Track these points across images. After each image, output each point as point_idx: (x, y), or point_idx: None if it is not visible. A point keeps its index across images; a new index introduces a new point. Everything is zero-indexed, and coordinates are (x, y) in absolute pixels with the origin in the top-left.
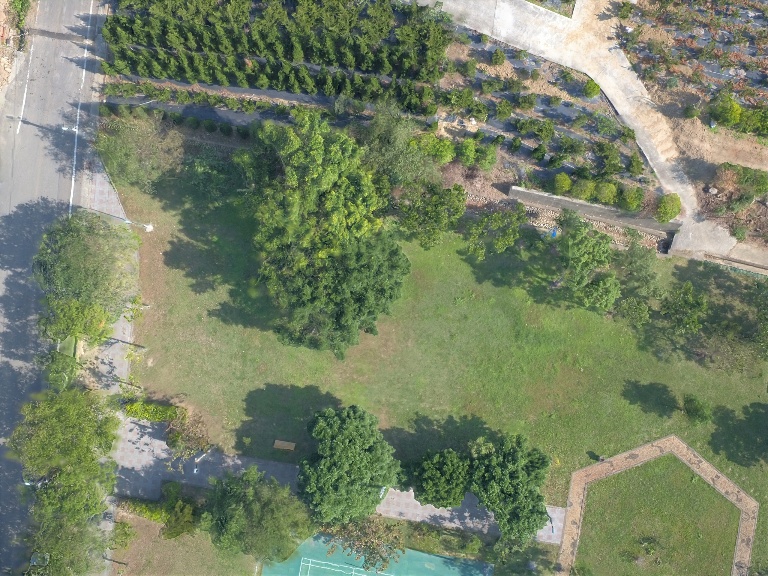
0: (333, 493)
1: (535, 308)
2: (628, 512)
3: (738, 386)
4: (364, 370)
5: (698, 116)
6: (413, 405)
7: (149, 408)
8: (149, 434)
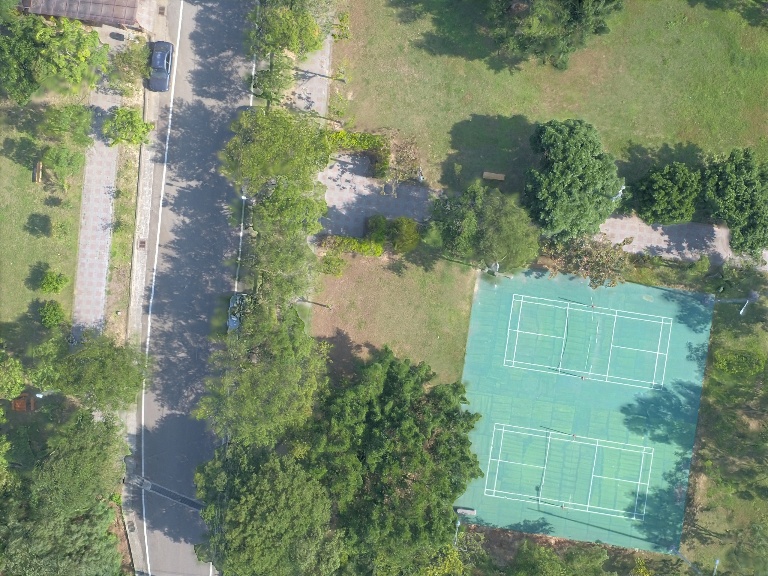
0: (566, 198)
1: (750, 31)
2: None
3: None
4: (574, 98)
5: None
6: (626, 133)
7: (356, 135)
8: (350, 170)
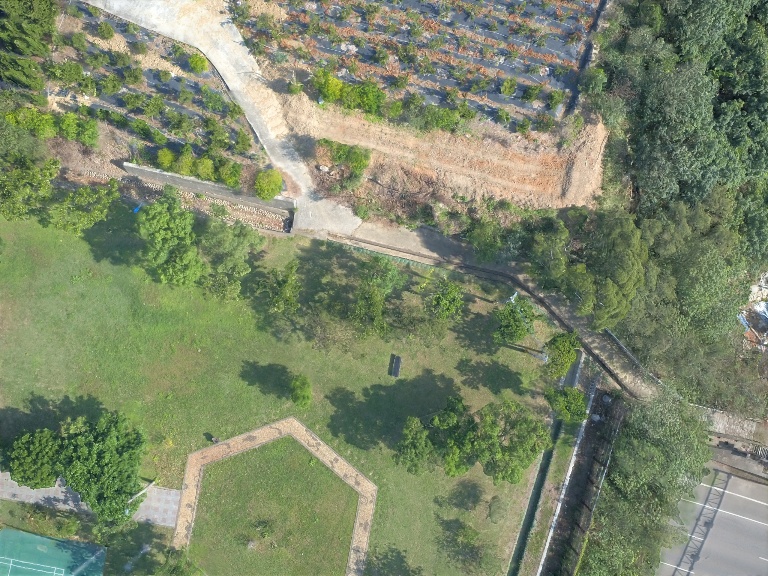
0: None
1: (153, 287)
2: (244, 495)
3: (359, 368)
4: None
5: (307, 92)
6: (28, 385)
7: None
8: None
